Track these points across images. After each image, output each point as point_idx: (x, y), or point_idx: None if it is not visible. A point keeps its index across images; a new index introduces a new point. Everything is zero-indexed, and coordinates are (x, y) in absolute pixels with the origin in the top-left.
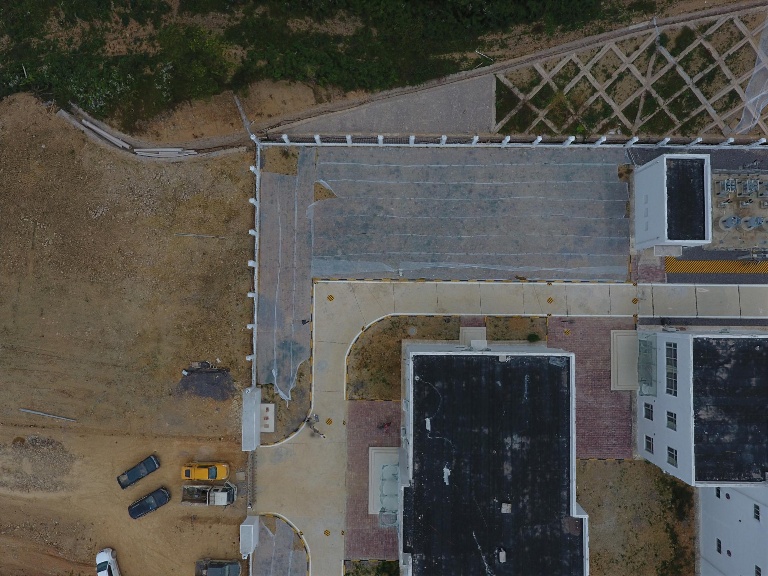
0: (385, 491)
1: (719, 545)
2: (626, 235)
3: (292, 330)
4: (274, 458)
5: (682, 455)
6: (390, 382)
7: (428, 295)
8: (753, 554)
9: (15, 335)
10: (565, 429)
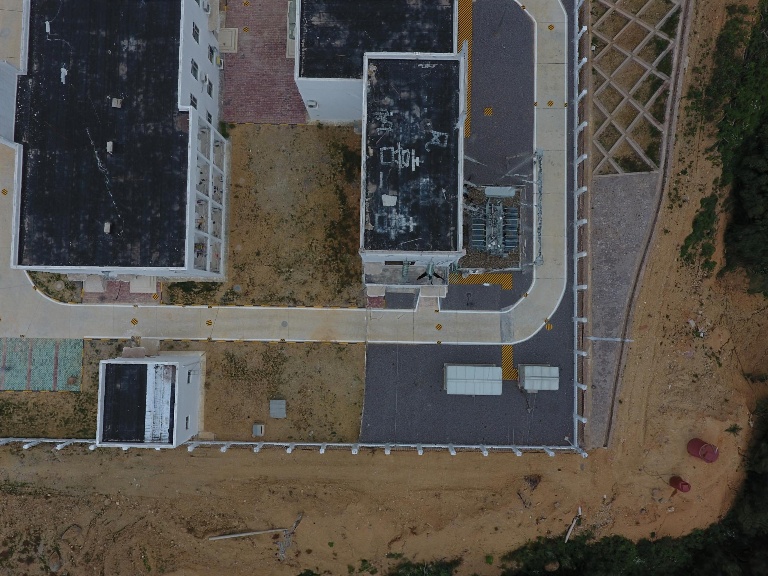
0: None
1: None
2: None
3: None
4: None
5: None
6: None
7: None
8: None
9: None
10: None
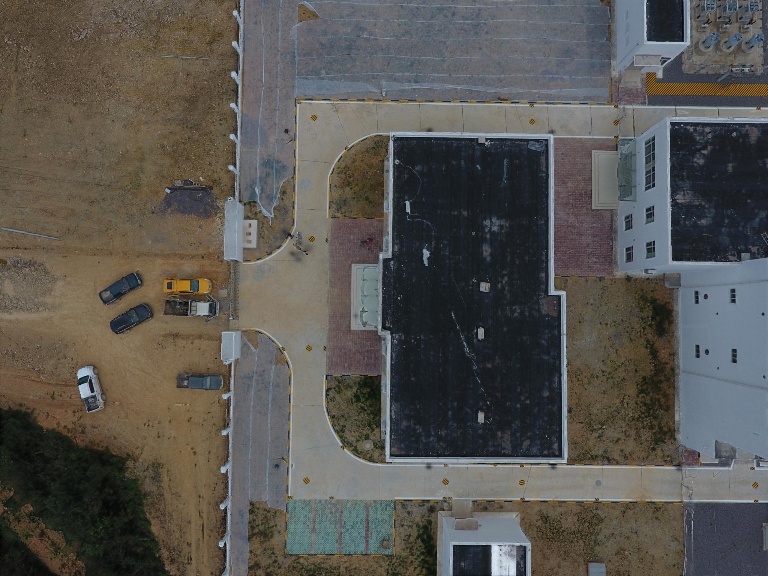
0: (367, 306)
1: (698, 350)
2: (607, 58)
3: (275, 149)
4: (257, 275)
5: (659, 240)
6: (373, 200)
7: (411, 115)
8: (729, 338)
9: None
10: (544, 212)
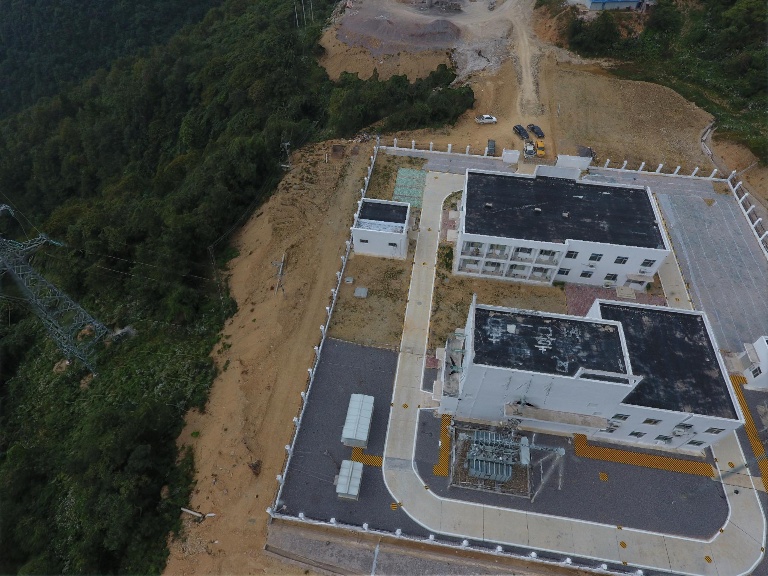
0: None
1: None
2: None
3: (622, 183)
4: None
5: None
6: None
7: None
8: None
9: (594, 106)
10: None
